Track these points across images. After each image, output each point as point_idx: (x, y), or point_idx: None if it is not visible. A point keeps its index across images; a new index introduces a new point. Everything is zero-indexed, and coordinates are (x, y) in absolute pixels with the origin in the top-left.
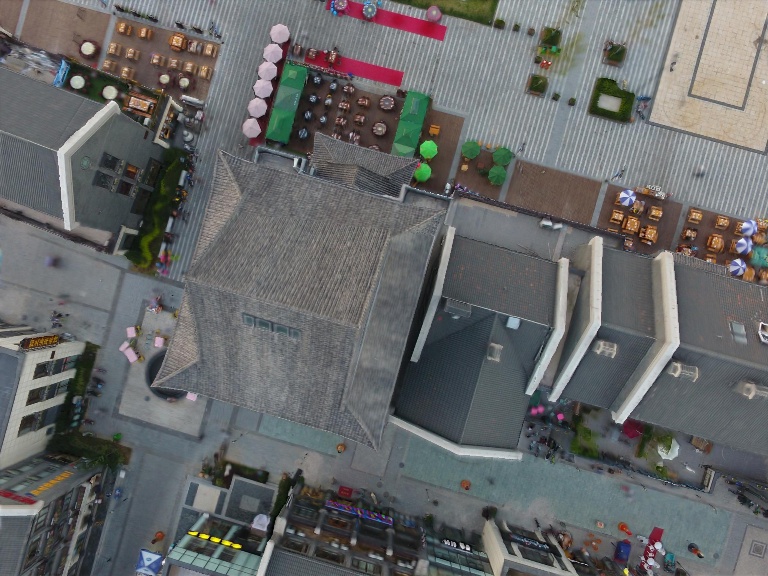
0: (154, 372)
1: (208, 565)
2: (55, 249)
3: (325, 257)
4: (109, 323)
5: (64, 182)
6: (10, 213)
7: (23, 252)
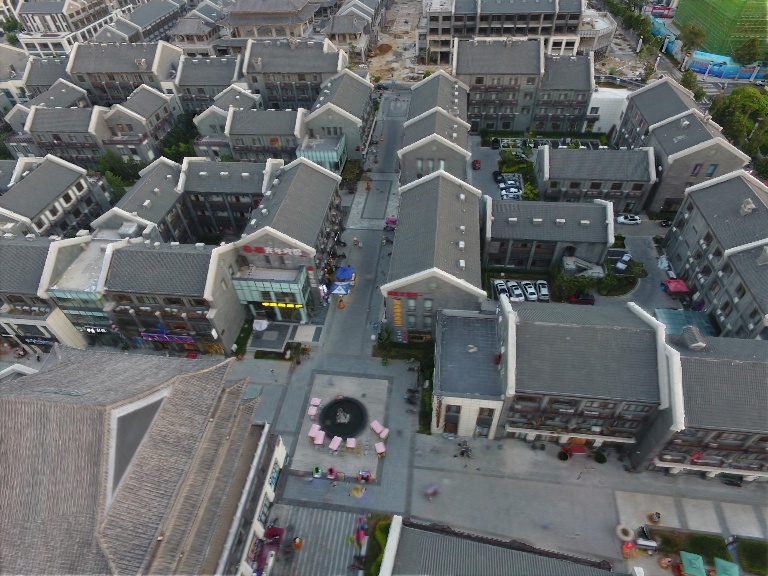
0: (360, 418)
1: (270, 285)
2: (491, 527)
3: (3, 471)
4: (412, 456)
5: (385, 563)
6: (520, 547)
7: (526, 517)
